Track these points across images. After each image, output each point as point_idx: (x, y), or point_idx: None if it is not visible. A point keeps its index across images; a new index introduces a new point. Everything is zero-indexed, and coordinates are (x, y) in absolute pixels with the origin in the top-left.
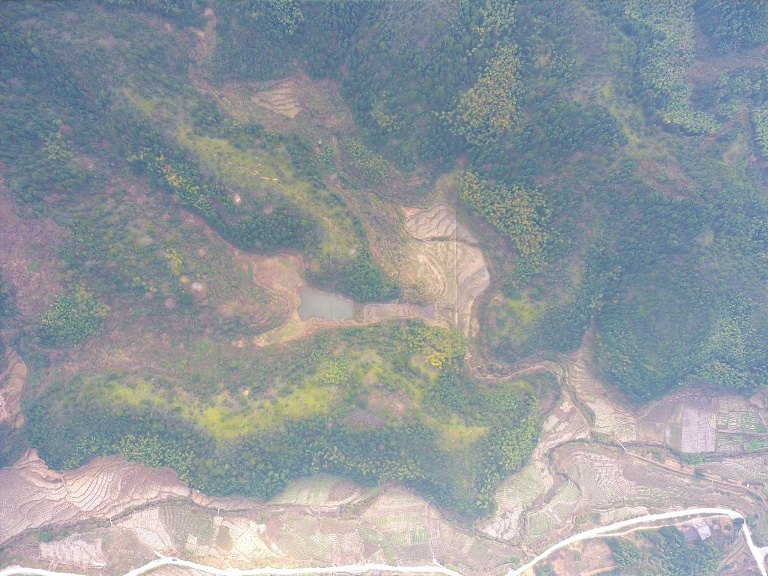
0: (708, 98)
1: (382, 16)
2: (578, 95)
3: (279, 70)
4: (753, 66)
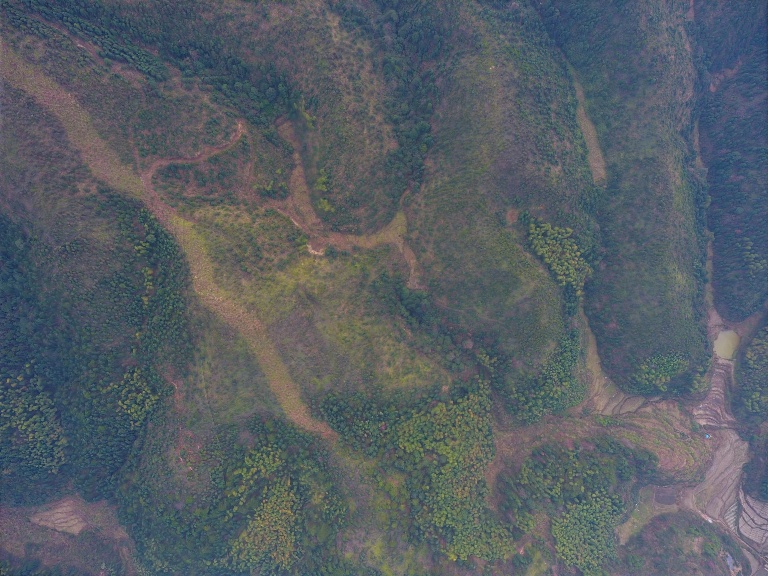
0: (509, 499)
1: (142, 464)
2: (350, 550)
3: (53, 497)
4: (560, 448)
